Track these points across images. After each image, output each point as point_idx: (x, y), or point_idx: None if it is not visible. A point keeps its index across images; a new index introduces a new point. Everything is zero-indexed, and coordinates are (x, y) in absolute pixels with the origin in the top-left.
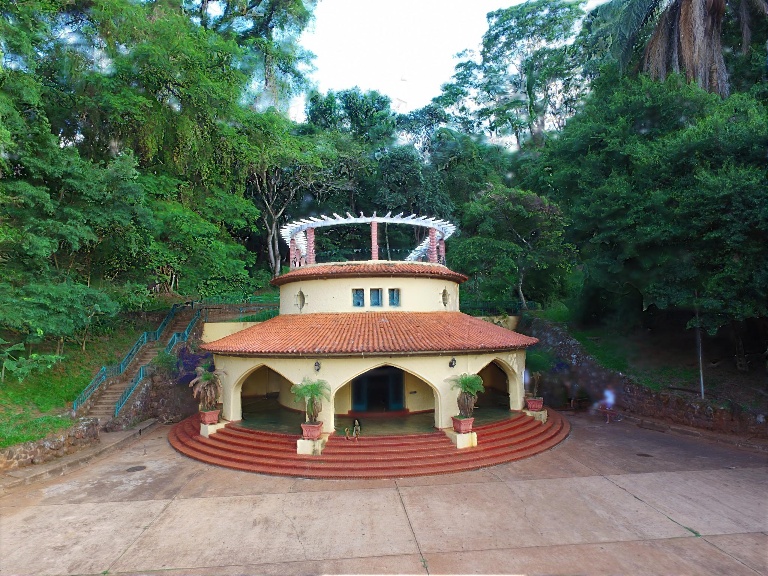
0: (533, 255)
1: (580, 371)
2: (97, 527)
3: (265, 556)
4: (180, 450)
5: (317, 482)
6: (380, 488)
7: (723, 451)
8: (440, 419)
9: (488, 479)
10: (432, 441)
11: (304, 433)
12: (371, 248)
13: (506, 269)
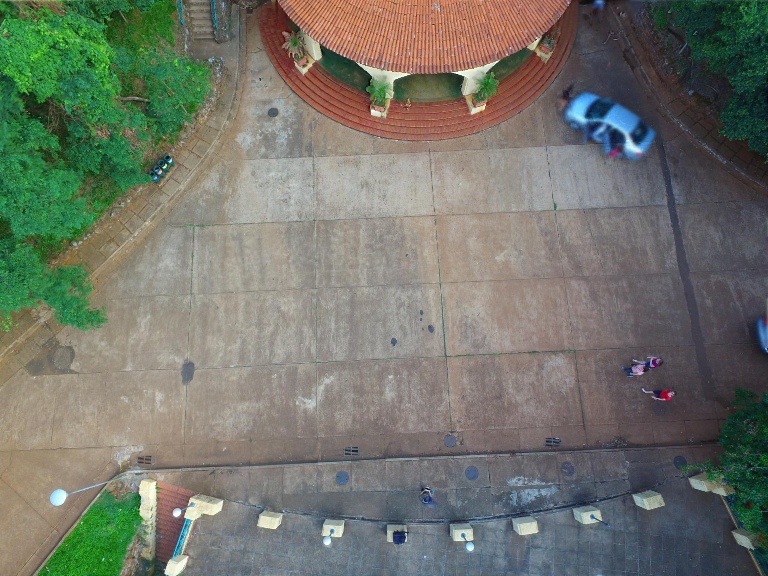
0: None
1: None
2: (291, 184)
3: (372, 213)
4: (288, 85)
5: (386, 142)
6: (420, 153)
7: (644, 112)
8: (465, 91)
9: (481, 146)
10: (456, 110)
11: None
12: None
13: None
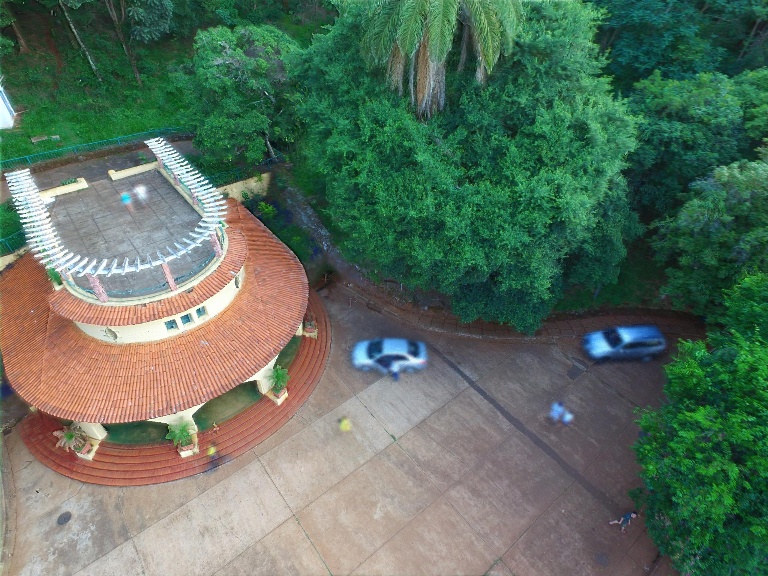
0: (280, 125)
1: (330, 256)
2: None
3: (227, 557)
4: (76, 479)
5: (209, 475)
6: (249, 464)
7: (408, 335)
8: (263, 390)
9: (302, 426)
10: (263, 409)
11: None
12: (167, 282)
13: (259, 156)
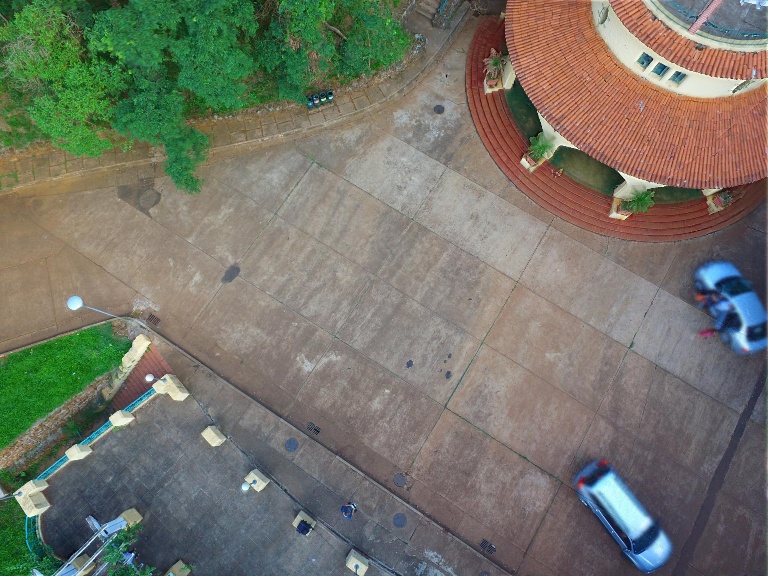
0: None
1: None
2: (413, 177)
3: (465, 245)
4: (467, 95)
5: (517, 193)
6: (541, 221)
7: None
8: (617, 193)
9: (599, 249)
10: (598, 204)
11: (527, 159)
12: (697, 18)
13: None
